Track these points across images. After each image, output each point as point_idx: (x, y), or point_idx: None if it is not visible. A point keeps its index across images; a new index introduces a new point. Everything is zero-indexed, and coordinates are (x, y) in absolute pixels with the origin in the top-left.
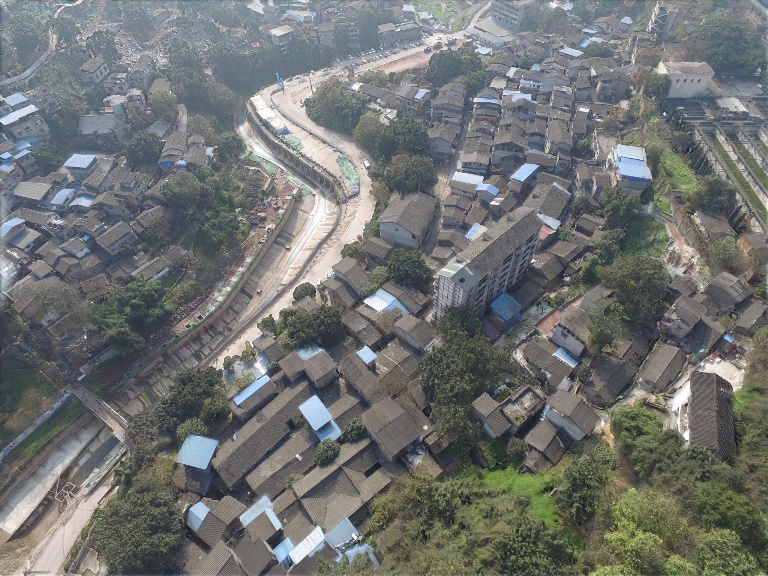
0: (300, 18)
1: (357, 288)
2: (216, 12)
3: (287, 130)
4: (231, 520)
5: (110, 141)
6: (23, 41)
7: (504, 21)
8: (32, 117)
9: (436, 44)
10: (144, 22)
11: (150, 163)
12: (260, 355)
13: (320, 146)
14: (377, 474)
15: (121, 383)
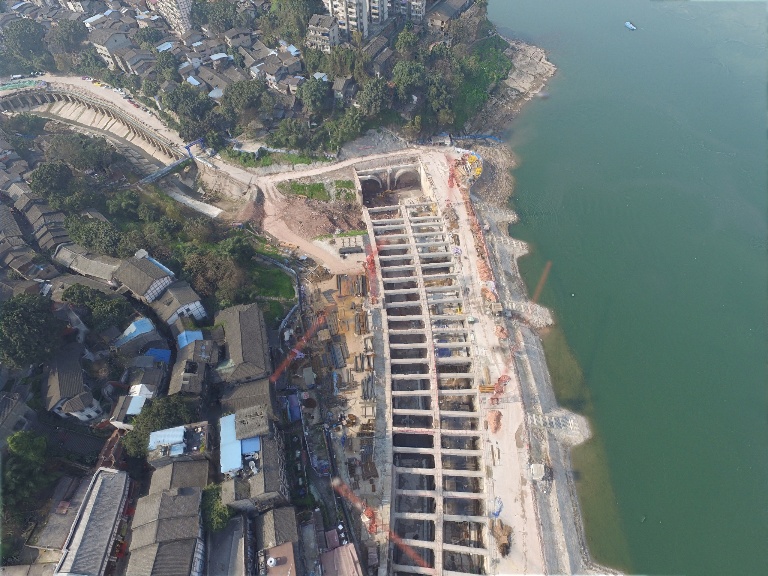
0: None
1: (150, 54)
2: None
3: None
4: (255, 78)
5: None
6: None
7: None
8: None
9: None
10: None
11: None
12: None
13: None
14: (254, 47)
15: None
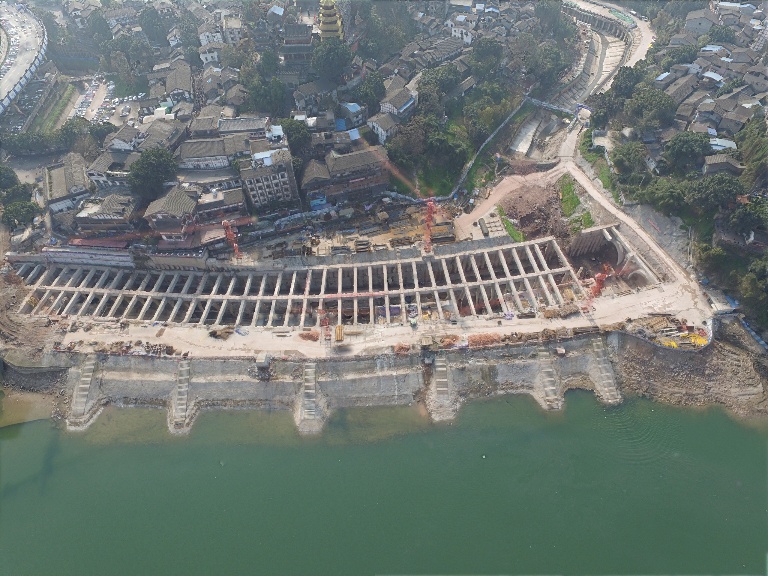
0: None
1: (693, 45)
2: None
3: None
4: None
5: None
6: None
7: None
8: None
9: None
10: None
11: None
12: None
13: (592, 5)
14: (759, 94)
15: (546, 100)
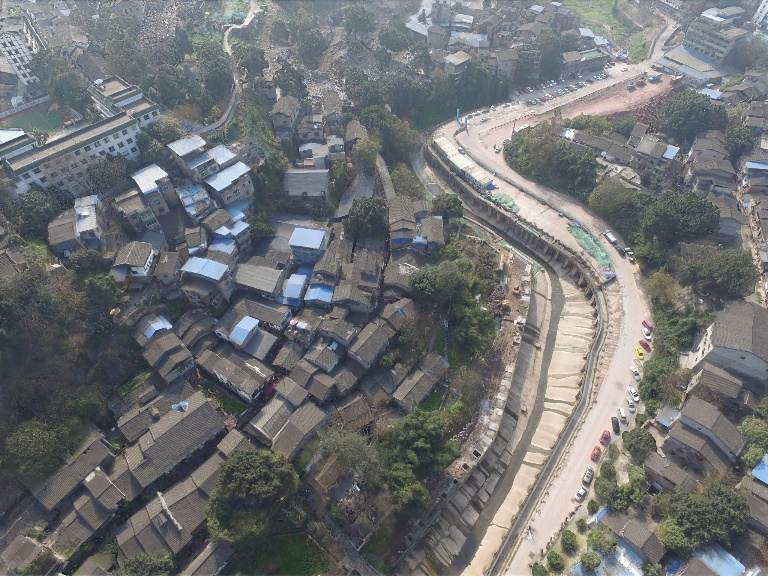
0: (471, 42)
1: (733, 451)
2: (385, 34)
3: (493, 185)
4: None
5: (318, 204)
6: (218, 79)
7: (702, 52)
8: (241, 177)
9: (641, 81)
10: (320, 48)
11: (374, 236)
12: (619, 543)
13: (539, 208)
14: None
15: (405, 552)
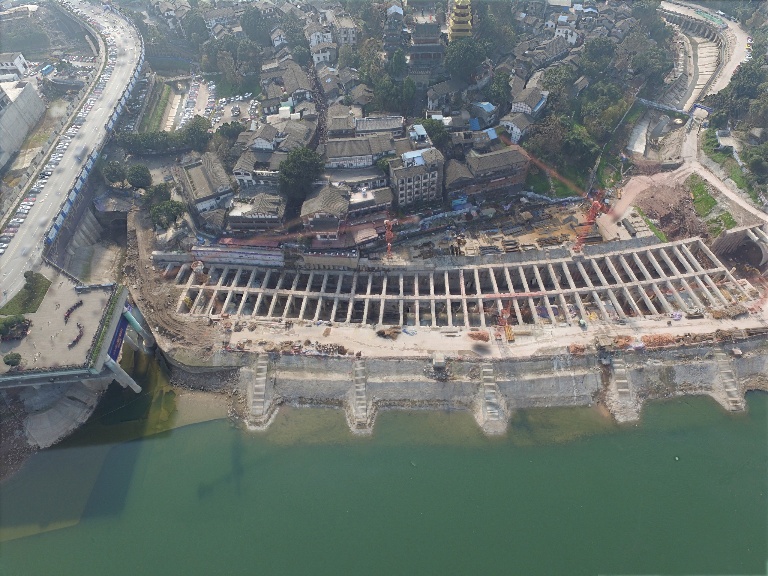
0: None
1: None
2: None
3: None
4: None
5: None
6: None
7: None
8: None
9: None
10: None
11: None
12: None
13: (676, 6)
14: None
15: None
